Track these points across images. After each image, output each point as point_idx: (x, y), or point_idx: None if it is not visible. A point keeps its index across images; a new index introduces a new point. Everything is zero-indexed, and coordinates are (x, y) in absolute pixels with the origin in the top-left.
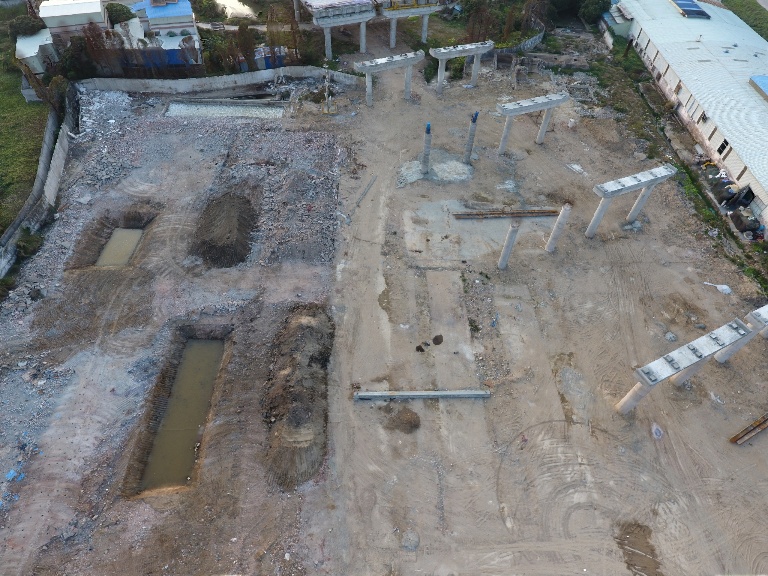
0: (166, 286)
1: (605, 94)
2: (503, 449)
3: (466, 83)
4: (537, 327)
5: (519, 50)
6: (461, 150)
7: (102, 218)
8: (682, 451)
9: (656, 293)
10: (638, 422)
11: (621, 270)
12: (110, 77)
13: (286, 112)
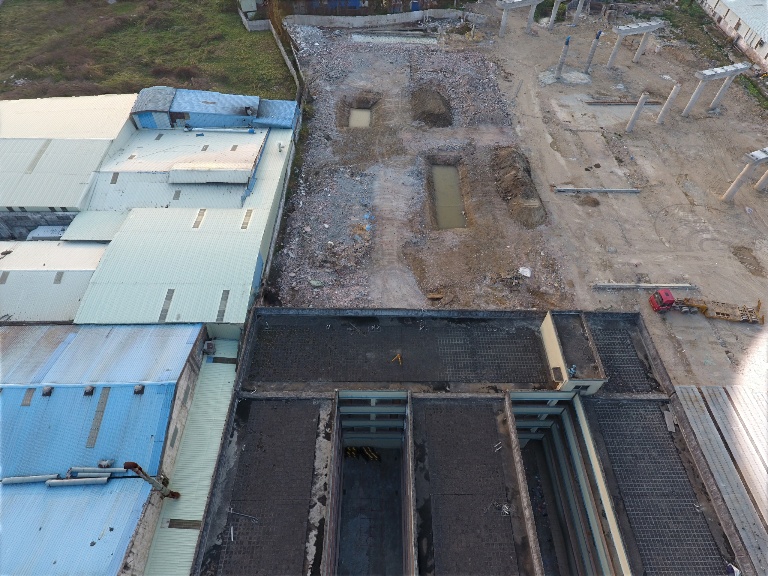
0: (408, 136)
1: (678, 32)
2: (655, 215)
3: (569, 23)
4: (661, 161)
5: (604, 1)
6: (579, 65)
7: (342, 101)
8: (766, 219)
9: (738, 146)
10: (736, 206)
11: (711, 134)
12: (306, 14)
13: (440, 40)
